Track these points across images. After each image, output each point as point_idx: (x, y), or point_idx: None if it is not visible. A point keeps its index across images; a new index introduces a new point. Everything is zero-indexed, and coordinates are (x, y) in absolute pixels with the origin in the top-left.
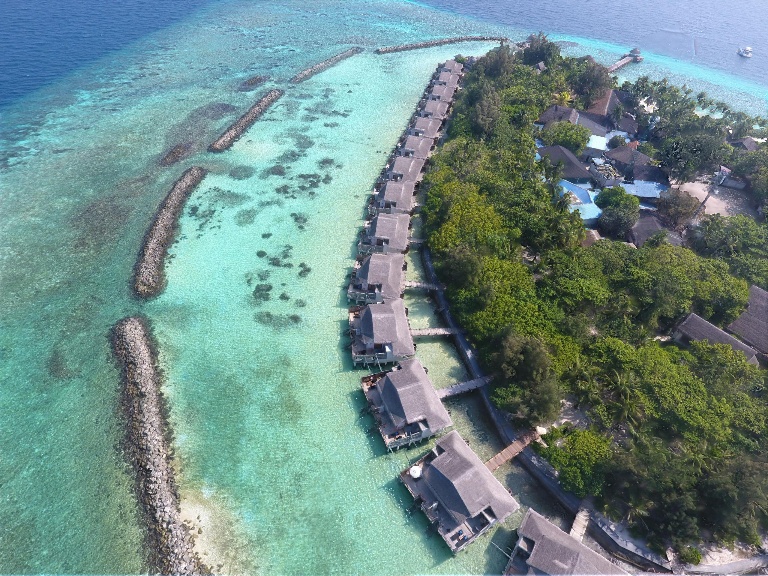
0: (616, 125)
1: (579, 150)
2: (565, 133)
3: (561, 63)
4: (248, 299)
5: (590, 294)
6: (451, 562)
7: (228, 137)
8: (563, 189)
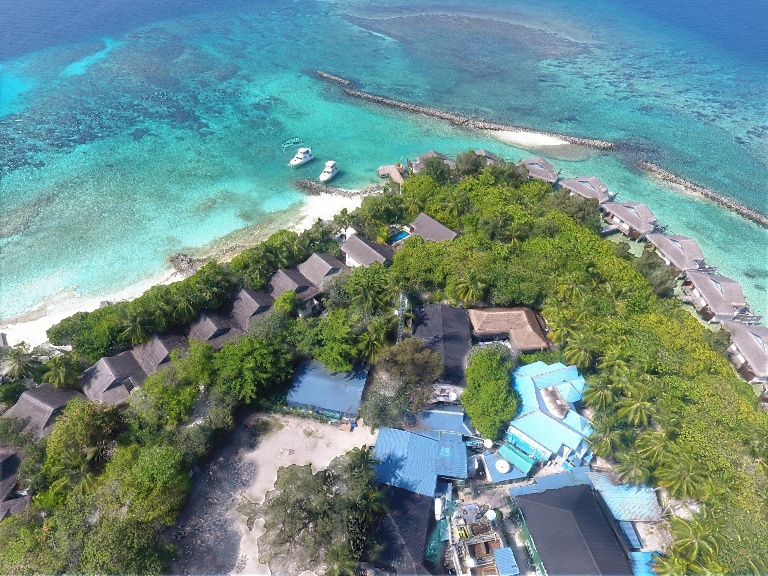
0: None
1: None
2: None
3: None
4: None
5: None
6: None
7: None
8: None
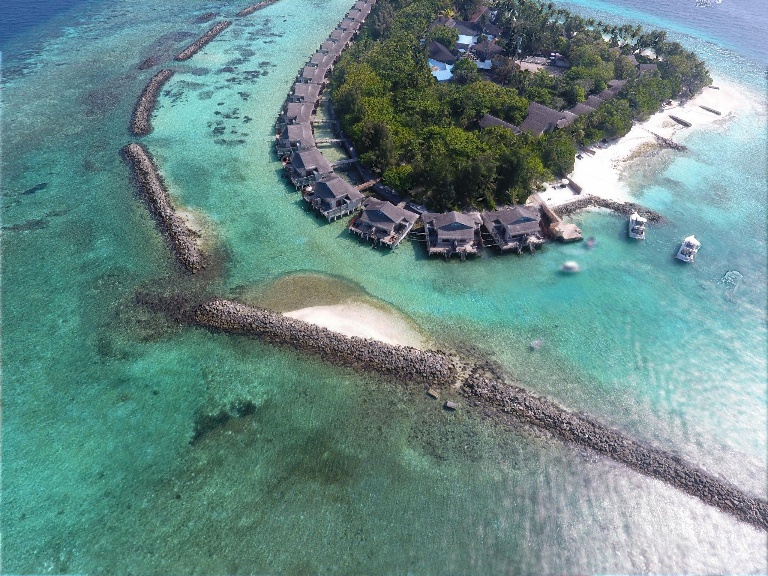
0: (485, 30)
1: (451, 45)
2: (440, 33)
3: None
4: (209, 134)
5: (425, 107)
6: (328, 226)
7: (189, 51)
8: (429, 64)
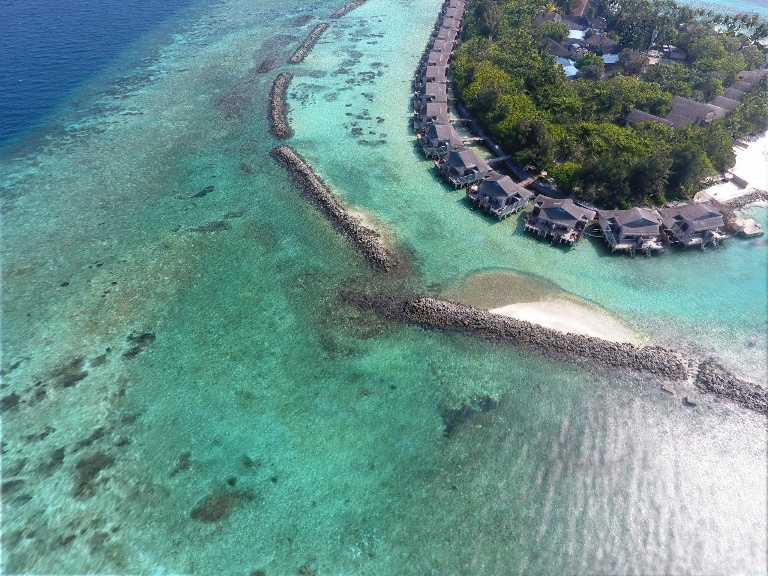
0: (590, 24)
1: (562, 40)
2: (551, 29)
3: None
4: (349, 135)
5: (570, 104)
6: (499, 224)
7: (299, 54)
8: None
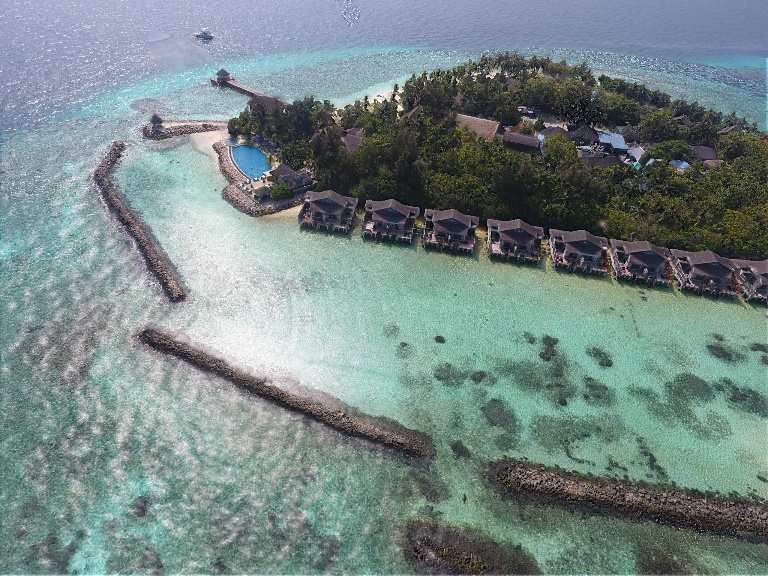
0: None
1: None
2: None
3: (318, 116)
4: None
5: None
6: None
7: None
8: None
